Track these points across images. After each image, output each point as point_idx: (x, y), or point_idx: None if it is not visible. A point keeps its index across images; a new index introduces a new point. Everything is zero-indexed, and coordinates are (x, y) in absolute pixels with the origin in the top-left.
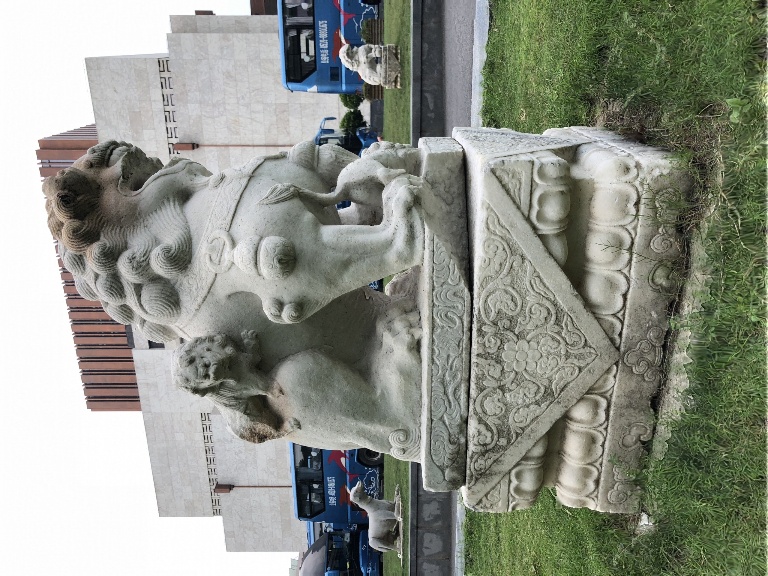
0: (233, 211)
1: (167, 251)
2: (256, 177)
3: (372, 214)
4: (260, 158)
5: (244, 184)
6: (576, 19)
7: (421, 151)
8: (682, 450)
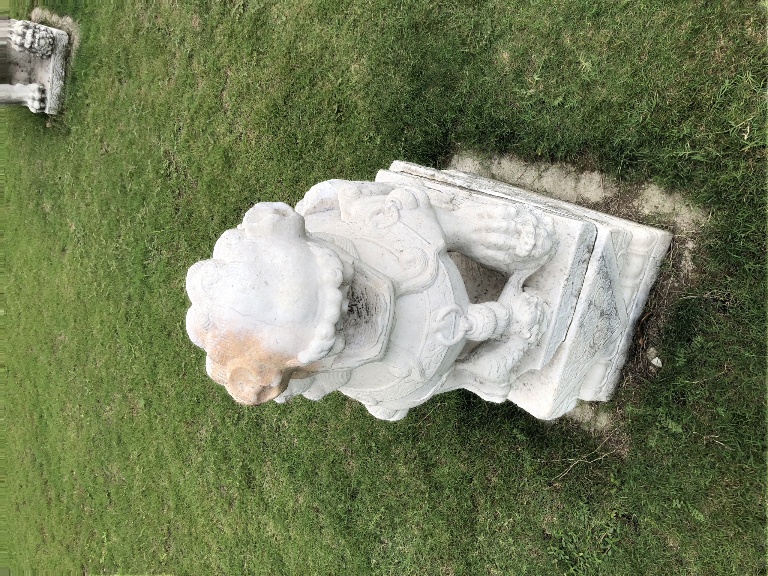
0: None
1: None
2: None
3: (478, 262)
4: None
5: None
6: None
7: (547, 331)
8: (470, 397)
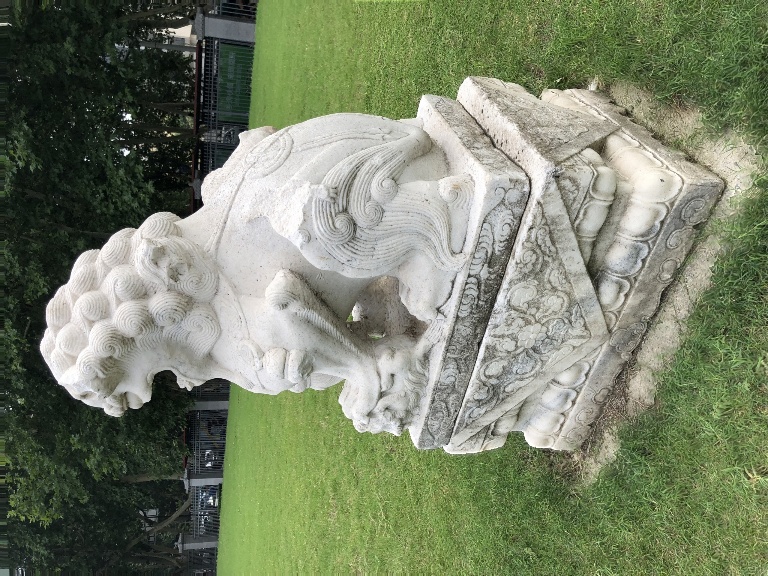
0: None
1: None
2: None
3: None
4: None
5: None
6: (562, 571)
7: None
8: None
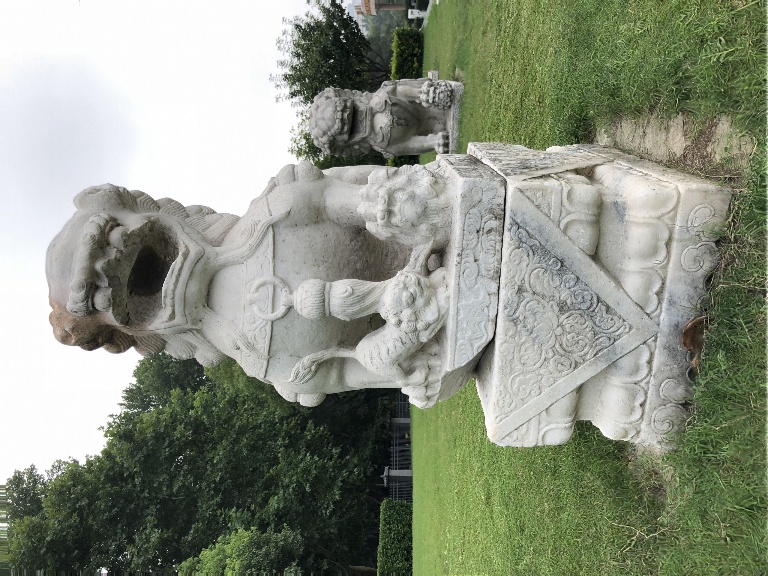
0: (263, 376)
1: (211, 365)
2: (273, 356)
3: None
4: (266, 320)
5: (265, 365)
6: None
7: (447, 321)
8: (583, 428)
